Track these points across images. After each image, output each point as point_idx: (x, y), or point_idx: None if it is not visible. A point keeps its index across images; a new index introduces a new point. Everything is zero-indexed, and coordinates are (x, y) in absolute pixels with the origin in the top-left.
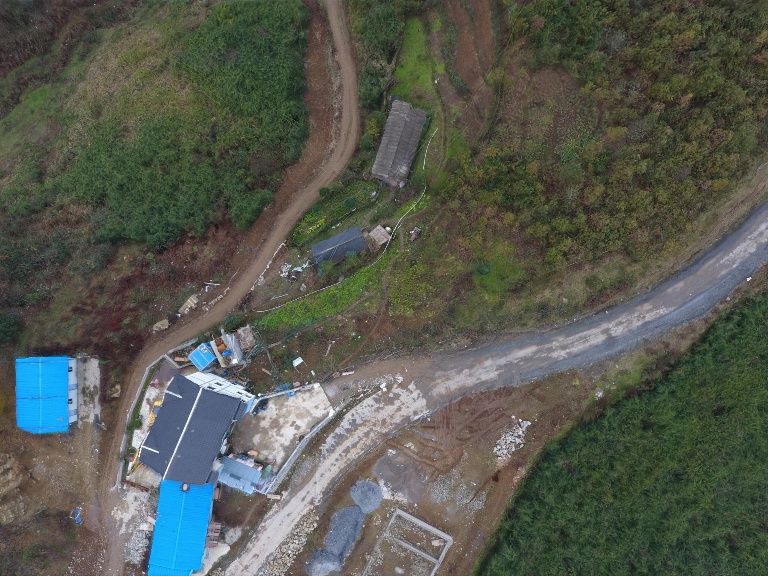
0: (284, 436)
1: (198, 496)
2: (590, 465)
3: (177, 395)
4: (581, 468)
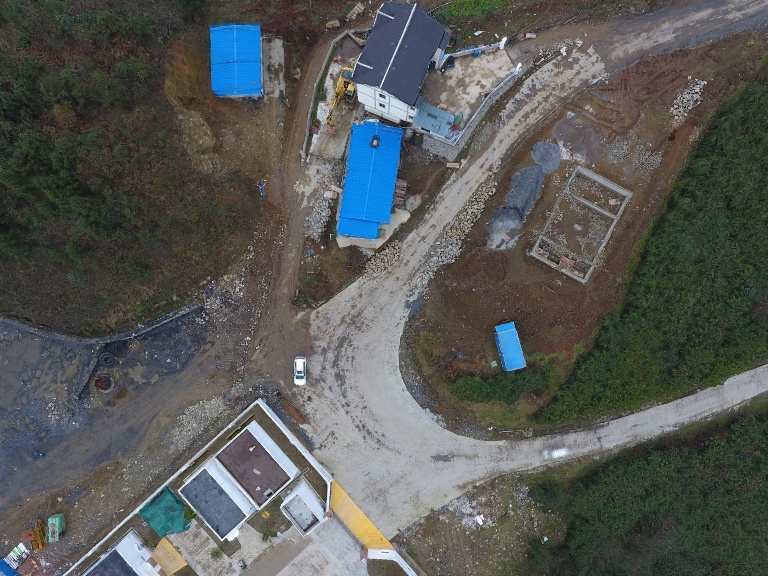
0: (470, 94)
1: (387, 153)
2: (763, 126)
3: (389, 16)
4: (754, 128)
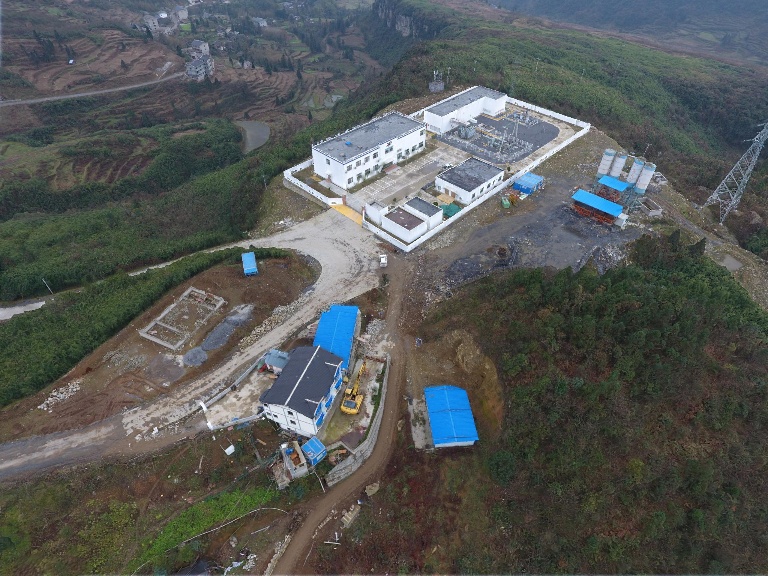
0: (248, 390)
1: None
2: None
3: (309, 401)
4: None
